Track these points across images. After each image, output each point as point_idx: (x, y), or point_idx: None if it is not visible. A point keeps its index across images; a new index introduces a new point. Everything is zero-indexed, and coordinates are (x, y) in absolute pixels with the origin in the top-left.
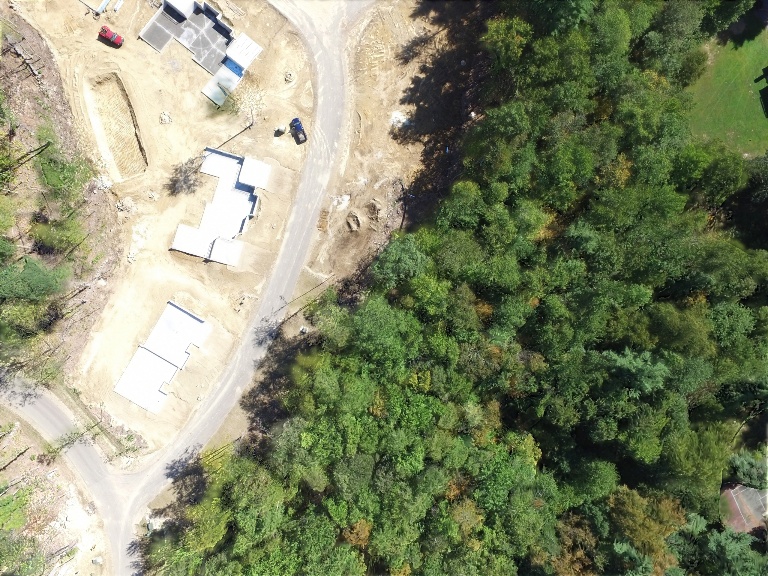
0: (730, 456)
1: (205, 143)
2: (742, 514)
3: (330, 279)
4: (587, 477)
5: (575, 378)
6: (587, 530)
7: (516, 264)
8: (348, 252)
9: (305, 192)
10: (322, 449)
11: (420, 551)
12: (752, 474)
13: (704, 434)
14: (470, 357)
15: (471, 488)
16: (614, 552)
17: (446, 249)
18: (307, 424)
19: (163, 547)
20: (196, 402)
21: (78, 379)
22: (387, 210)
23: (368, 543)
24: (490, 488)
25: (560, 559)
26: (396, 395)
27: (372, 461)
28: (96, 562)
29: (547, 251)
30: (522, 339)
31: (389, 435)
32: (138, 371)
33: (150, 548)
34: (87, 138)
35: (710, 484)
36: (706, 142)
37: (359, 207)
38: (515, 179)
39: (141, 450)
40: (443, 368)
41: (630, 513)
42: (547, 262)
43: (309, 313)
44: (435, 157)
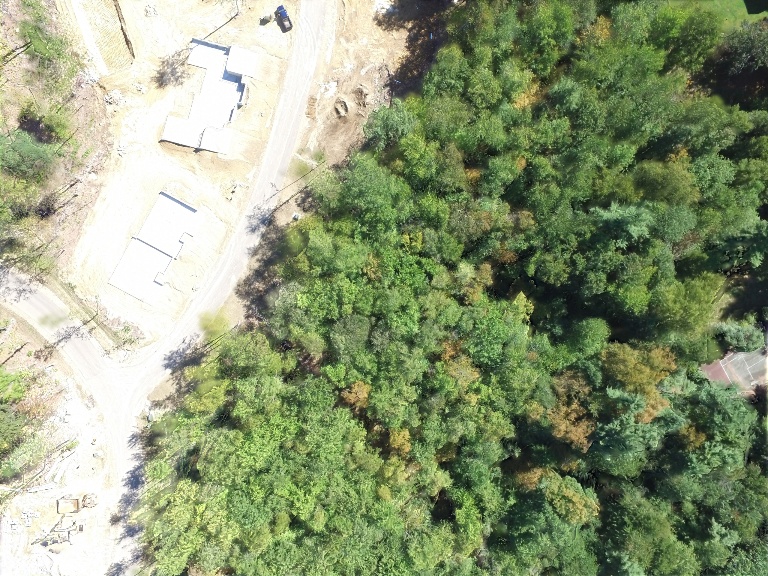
0: (717, 325)
1: (191, 35)
2: (731, 381)
3: (320, 166)
4: (579, 334)
5: (563, 231)
6: (580, 381)
7: (502, 128)
8: (337, 138)
9: (292, 79)
10: (318, 309)
11: (418, 412)
12: (739, 336)
13: (690, 283)
14: (460, 218)
15: (466, 345)
16: (607, 402)
17: (433, 111)
18: (302, 289)
19: (164, 439)
20: (191, 292)
21: (72, 273)
22: (374, 96)
23: (367, 405)
24: (484, 341)
25: (555, 412)
26: (389, 254)
27: (368, 322)
28: (97, 455)
29: (532, 110)
30: (511, 205)
31: (383, 295)
32: (132, 263)
33: (151, 440)
34: (73, 32)
35: (697, 324)
36: (682, 4)
37: (346, 93)
38: (498, 43)
39: (138, 341)
40: (434, 230)
41: (621, 360)
42: (532, 122)
43: (301, 200)
44: (420, 43)
